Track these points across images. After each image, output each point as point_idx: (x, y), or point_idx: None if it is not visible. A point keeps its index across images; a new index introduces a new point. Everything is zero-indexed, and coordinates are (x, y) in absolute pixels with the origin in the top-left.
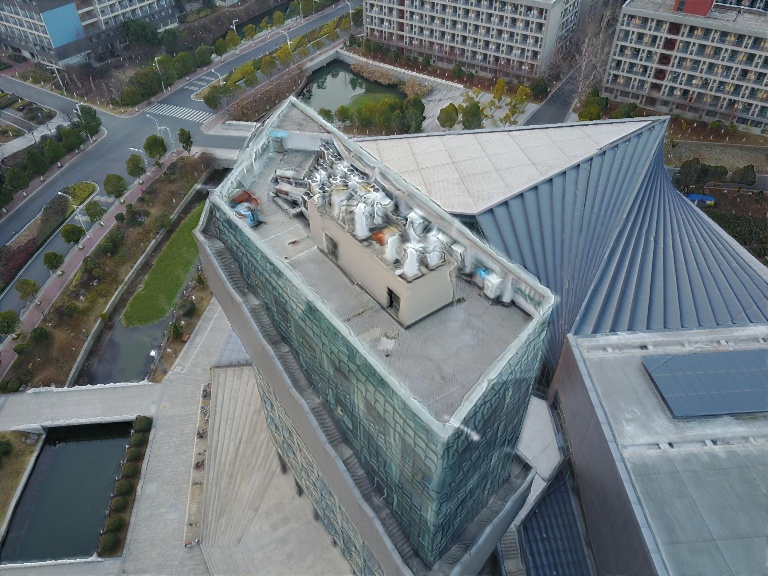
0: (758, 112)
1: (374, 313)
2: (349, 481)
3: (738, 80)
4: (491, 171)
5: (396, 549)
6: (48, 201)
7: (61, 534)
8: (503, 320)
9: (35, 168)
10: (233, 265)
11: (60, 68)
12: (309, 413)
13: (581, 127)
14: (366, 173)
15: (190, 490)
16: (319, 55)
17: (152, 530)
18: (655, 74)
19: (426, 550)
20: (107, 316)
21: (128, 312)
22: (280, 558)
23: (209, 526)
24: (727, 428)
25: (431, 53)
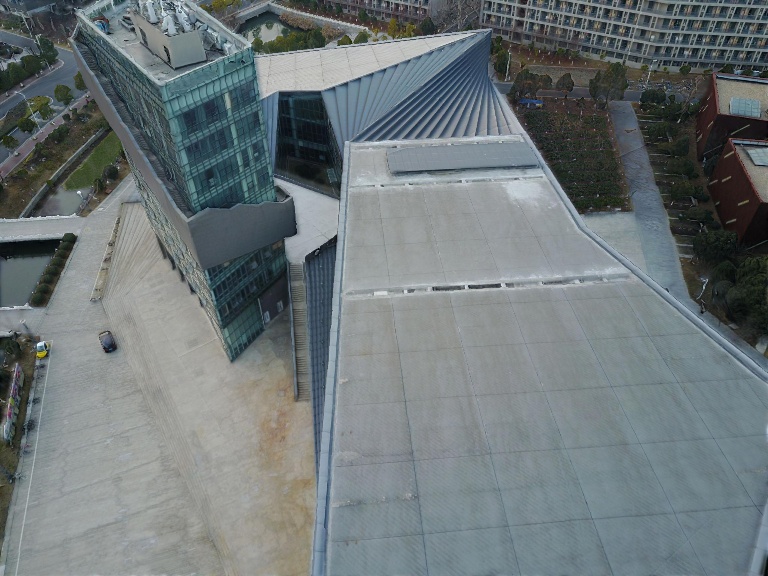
0: (596, 41)
1: (160, 65)
2: (150, 168)
3: (578, 14)
4: (346, 67)
5: (173, 200)
6: (11, 108)
7: (6, 303)
8: (231, 66)
9: (0, 84)
10: (94, 60)
11: (28, 17)
12: (130, 133)
13: (425, 39)
14: (178, 5)
15: (99, 273)
16: (253, 7)
17: (69, 294)
18: (519, 13)
19: (188, 197)
20: (52, 183)
21: (69, 181)
22: (153, 300)
23: (109, 289)
24: (422, 178)
25: (346, 3)
